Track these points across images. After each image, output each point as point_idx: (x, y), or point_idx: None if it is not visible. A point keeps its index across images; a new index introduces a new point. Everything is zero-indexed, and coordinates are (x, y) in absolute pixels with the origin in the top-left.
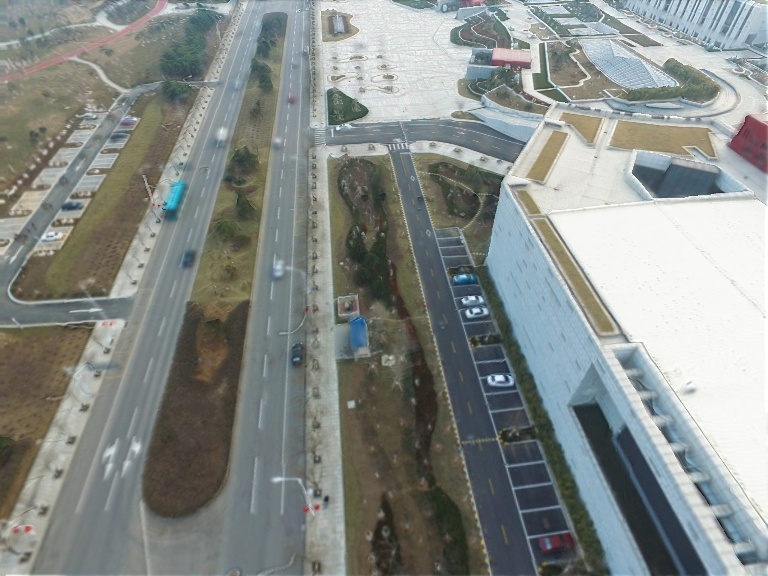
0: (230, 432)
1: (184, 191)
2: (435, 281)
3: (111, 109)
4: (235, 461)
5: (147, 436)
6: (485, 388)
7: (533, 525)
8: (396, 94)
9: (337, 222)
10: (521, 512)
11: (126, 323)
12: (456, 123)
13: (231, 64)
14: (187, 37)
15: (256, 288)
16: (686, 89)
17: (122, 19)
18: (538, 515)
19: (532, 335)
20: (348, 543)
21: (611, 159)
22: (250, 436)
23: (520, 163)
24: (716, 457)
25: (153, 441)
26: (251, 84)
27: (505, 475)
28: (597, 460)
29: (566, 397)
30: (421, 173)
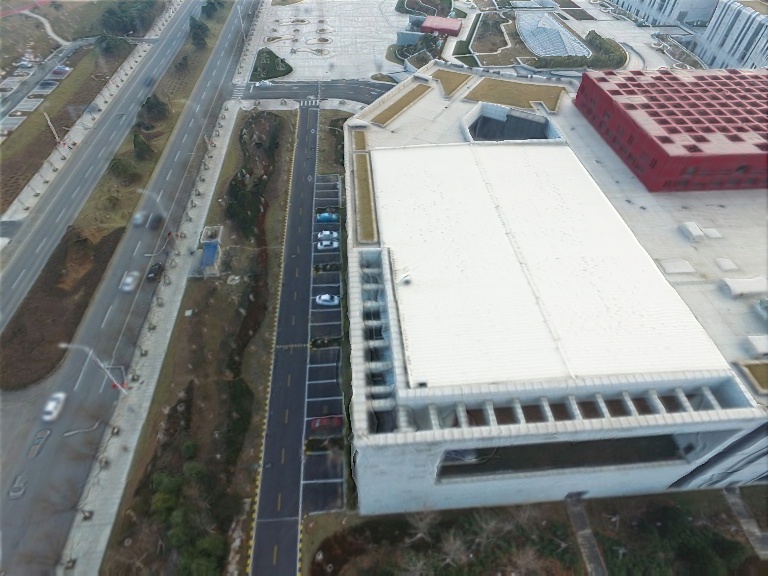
0: (74, 329)
1: (95, 134)
2: (301, 218)
3: (48, 59)
4: (73, 351)
5: (1, 329)
6: (313, 305)
7: (314, 410)
8: (325, 56)
9: (228, 166)
10: (307, 400)
11: (10, 241)
12: (373, 84)
13: (175, 23)
14: None
15: (135, 217)
16: (591, 59)
17: None
18: (321, 403)
19: None
20: (149, 415)
21: (459, 109)
22: (92, 333)
23: (372, 109)
24: (393, 326)
25: (5, 333)
26: (187, 42)
27: (304, 372)
28: None
29: None
30: (322, 127)
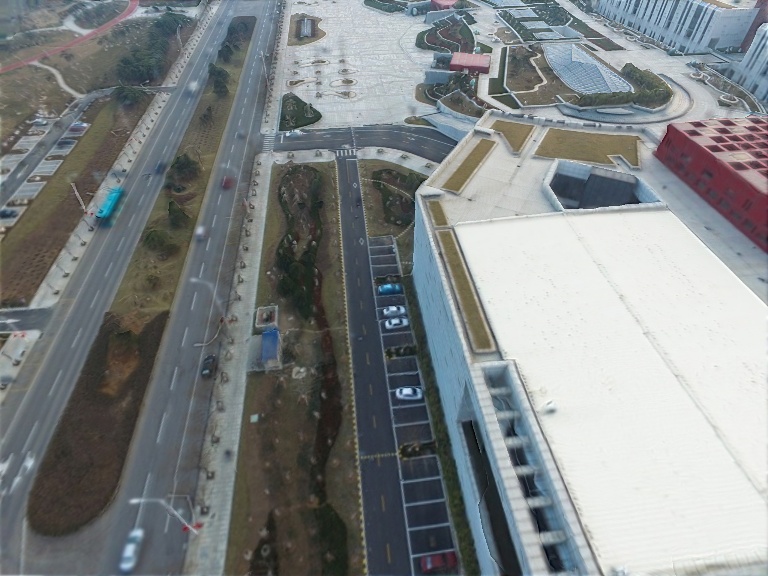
0: (126, 447)
1: (122, 199)
2: (360, 291)
3: (63, 115)
4: (127, 477)
5: (42, 451)
6: (393, 401)
7: (419, 543)
8: (352, 99)
9: (271, 230)
10: (409, 530)
11: (41, 334)
12: (408, 129)
13: (192, 69)
14: (150, 41)
15: (178, 298)
16: (637, 95)
17: (89, 23)
18: (425, 533)
19: (436, 348)
20: (227, 562)
21: (533, 168)
22: (147, 451)
23: (440, 172)
24: (557, 481)
25: (46, 457)
26: (208, 89)
27: (399, 491)
28: (475, 478)
29: (455, 413)
30: (364, 180)
